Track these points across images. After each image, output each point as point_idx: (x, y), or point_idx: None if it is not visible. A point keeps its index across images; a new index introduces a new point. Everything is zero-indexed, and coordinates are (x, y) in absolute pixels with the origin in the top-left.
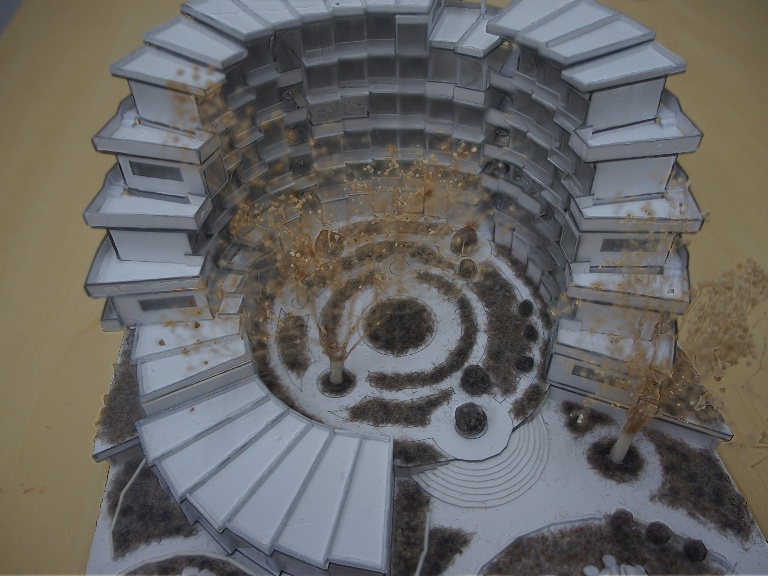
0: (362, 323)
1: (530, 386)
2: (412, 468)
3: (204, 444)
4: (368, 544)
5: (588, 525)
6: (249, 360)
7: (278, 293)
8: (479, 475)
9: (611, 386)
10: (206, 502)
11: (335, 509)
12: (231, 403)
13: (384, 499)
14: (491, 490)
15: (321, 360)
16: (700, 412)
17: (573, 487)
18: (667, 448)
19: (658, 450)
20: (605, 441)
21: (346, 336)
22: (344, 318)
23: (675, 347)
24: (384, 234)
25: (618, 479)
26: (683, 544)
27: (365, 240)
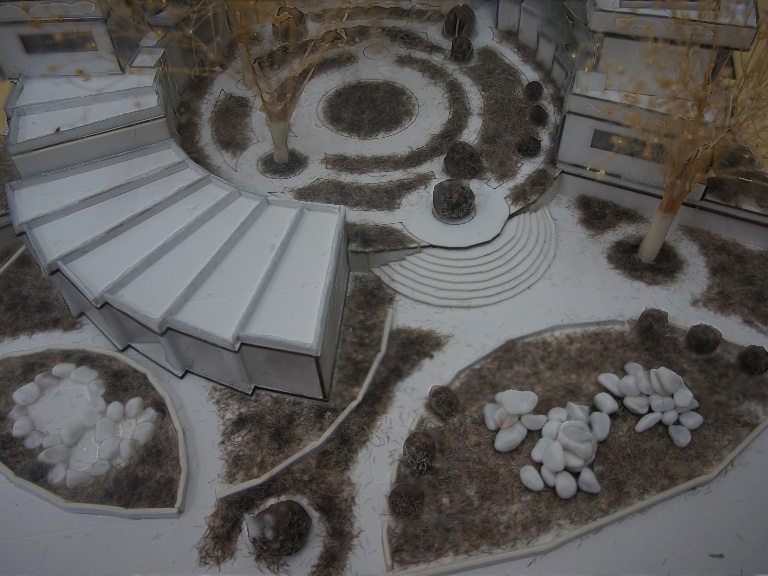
0: (323, 105)
1: (535, 171)
2: (371, 254)
3: (94, 212)
4: (297, 322)
5: (606, 330)
6: (161, 115)
7: (220, 74)
8: (461, 266)
9: (643, 160)
10: (84, 273)
11: (257, 283)
12: (137, 170)
13: (325, 273)
14: (476, 285)
15: (265, 140)
16: (762, 198)
17: (587, 288)
18: (715, 248)
19: (703, 250)
20: (632, 239)
21: (301, 117)
22: (300, 100)
23: (733, 102)
24: (360, 20)
25: (648, 280)
26: (737, 354)
27: (336, 25)
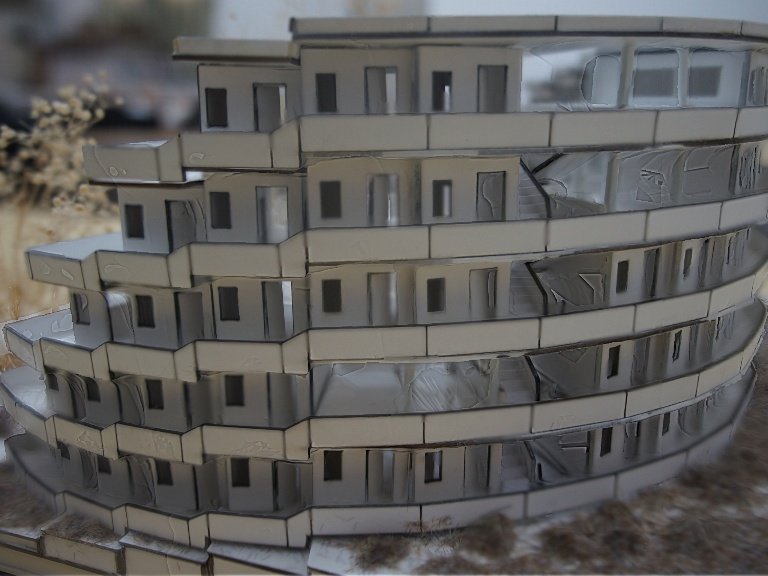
0: None
1: None
2: None
3: None
4: None
5: None
6: None
7: None
8: None
9: None
10: None
11: None
12: None
13: None
14: None
15: None
16: None
17: None
18: None
19: None
20: None
21: None
22: None
23: (9, 392)
24: None
25: None
26: None
27: None
